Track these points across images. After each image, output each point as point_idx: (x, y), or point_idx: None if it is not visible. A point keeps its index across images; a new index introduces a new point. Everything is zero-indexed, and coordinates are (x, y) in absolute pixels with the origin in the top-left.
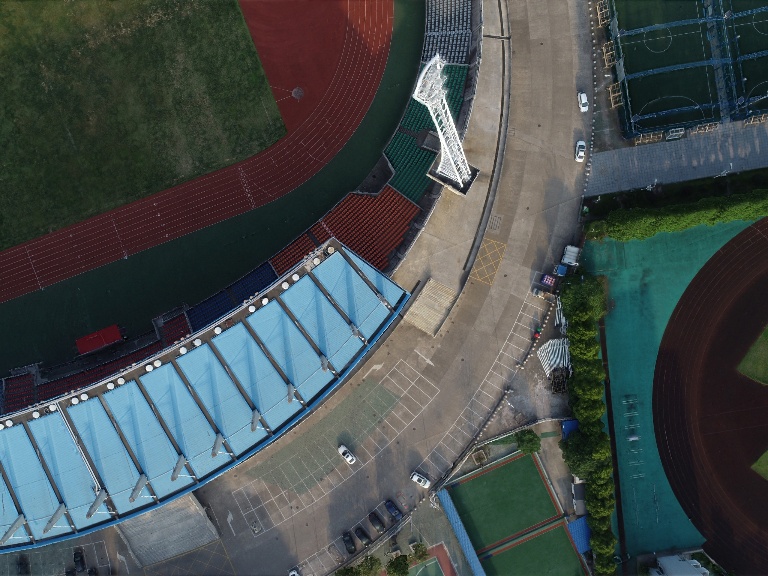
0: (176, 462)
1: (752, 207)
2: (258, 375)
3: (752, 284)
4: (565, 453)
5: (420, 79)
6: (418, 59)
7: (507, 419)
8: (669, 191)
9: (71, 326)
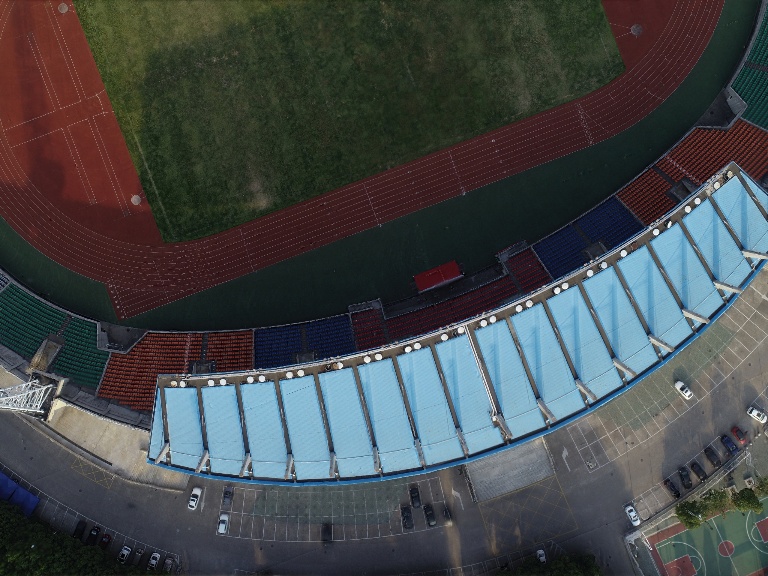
0: (573, 386)
1: None
2: (656, 299)
3: None
4: None
5: None
6: None
7: None
8: None
9: (408, 262)
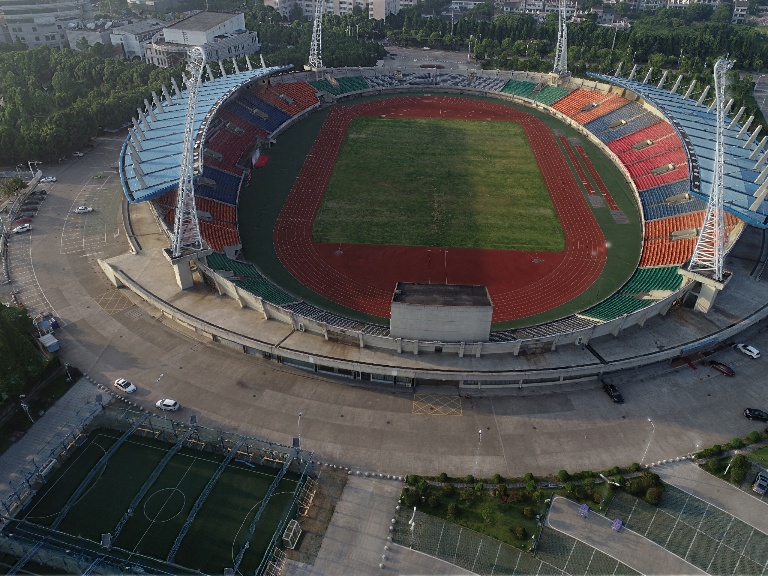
0: None
1: None
2: None
3: None
4: None
5: None
6: None
7: None
8: (1, 444)
9: None
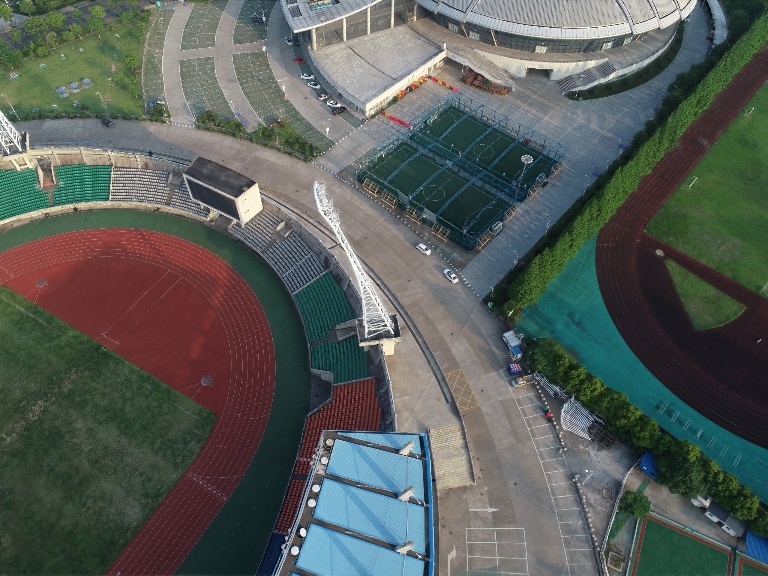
0: None
1: (584, 217)
2: None
3: (638, 274)
4: (670, 484)
5: (316, 196)
6: (288, 298)
7: (599, 504)
8: (529, 259)
9: None
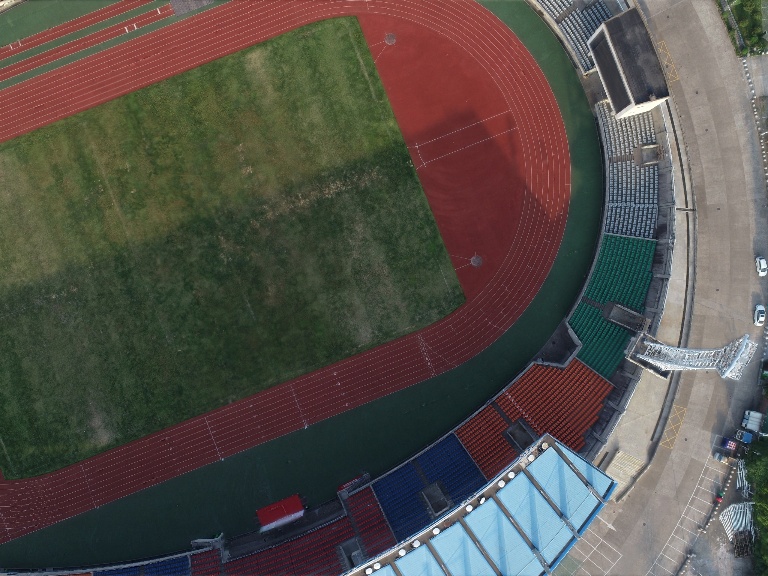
0: None
1: None
2: (473, 572)
3: None
4: None
5: (734, 364)
6: (596, 225)
7: None
8: None
9: (251, 496)
